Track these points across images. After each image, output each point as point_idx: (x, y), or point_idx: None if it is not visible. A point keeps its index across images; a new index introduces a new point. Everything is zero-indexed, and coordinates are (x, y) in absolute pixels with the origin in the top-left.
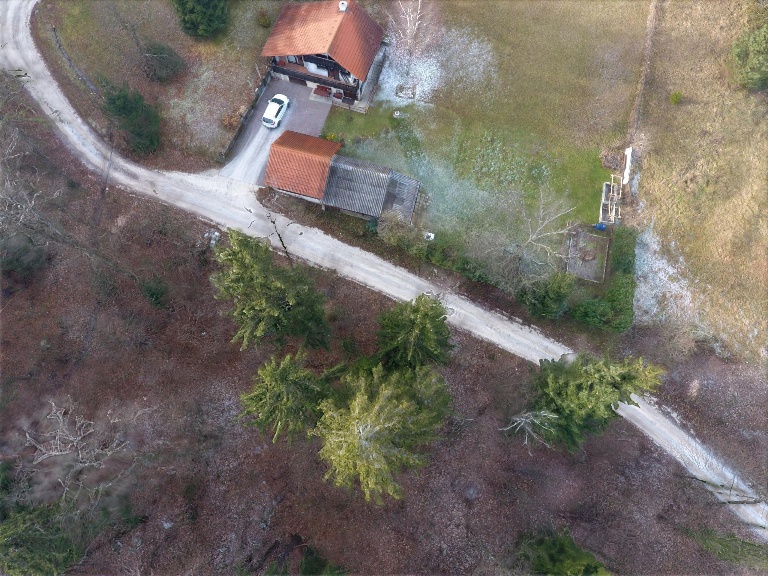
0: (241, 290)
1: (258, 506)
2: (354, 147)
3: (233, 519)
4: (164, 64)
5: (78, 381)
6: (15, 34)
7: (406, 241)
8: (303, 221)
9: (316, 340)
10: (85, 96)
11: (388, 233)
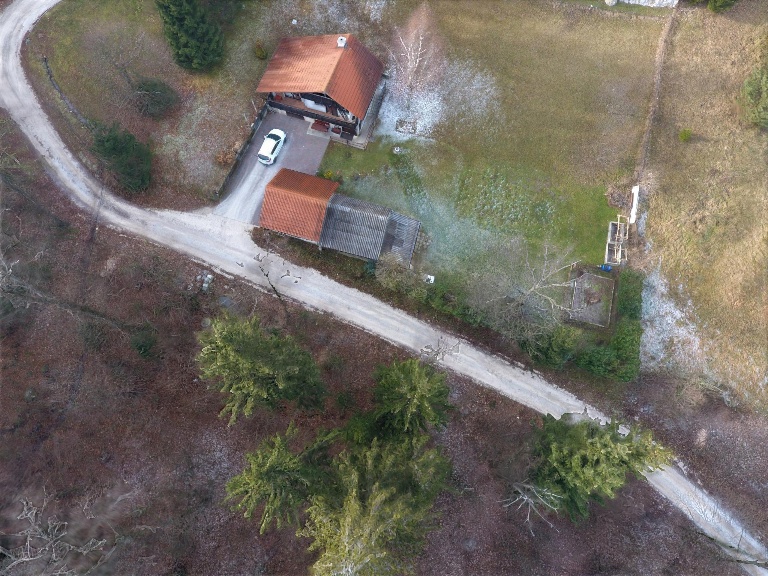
0: (227, 373)
1: (249, 561)
2: (352, 184)
3: (223, 575)
4: (156, 100)
5: (64, 433)
6: (5, 64)
7: (405, 286)
8: (299, 261)
9: (310, 400)
10: (76, 130)
11: (386, 278)
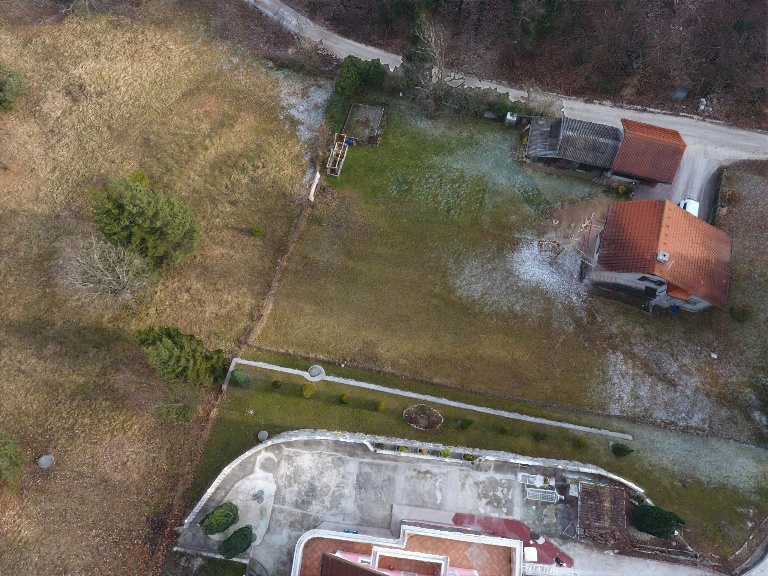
0: None
1: None
2: (593, 192)
3: None
4: None
5: (766, 11)
6: None
7: None
8: None
9: None
10: None
11: None
